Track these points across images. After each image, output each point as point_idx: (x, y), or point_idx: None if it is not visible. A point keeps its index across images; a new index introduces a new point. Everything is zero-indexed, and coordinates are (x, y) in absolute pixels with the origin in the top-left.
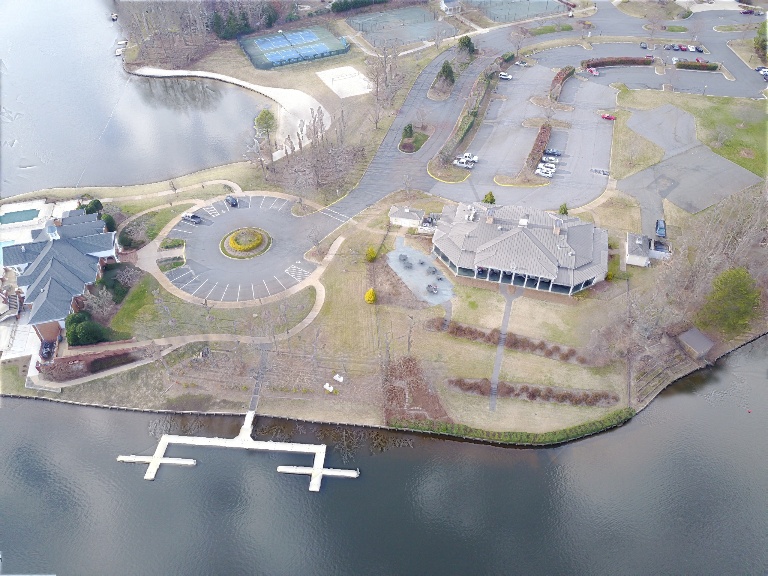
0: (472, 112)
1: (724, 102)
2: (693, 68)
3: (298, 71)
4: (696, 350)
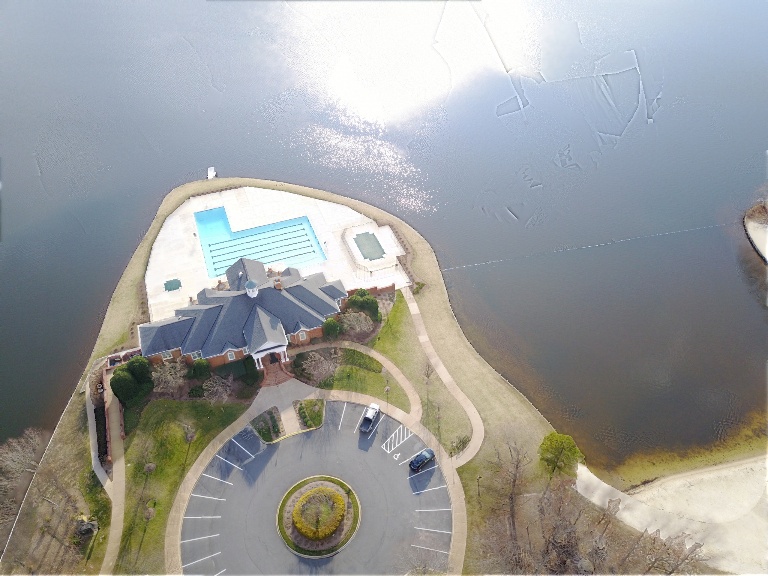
0: None
1: None
2: None
3: None
4: None
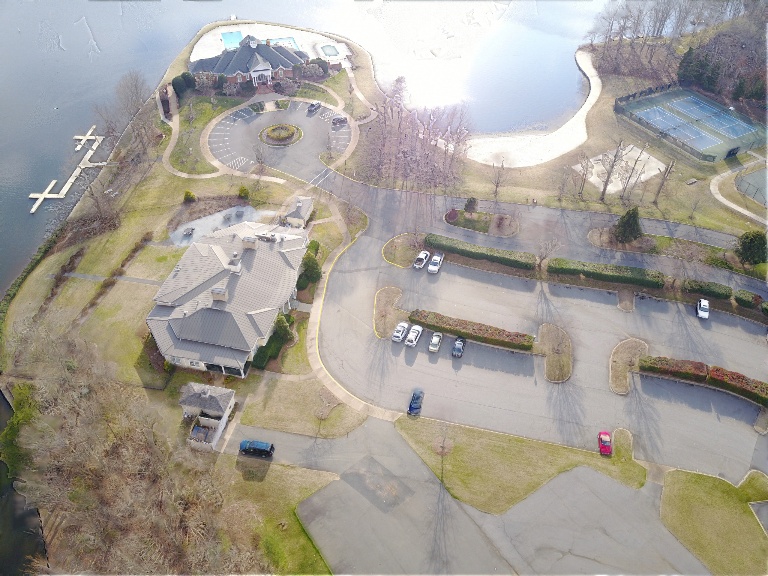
0: (549, 263)
1: None
2: None
3: (629, 133)
4: None
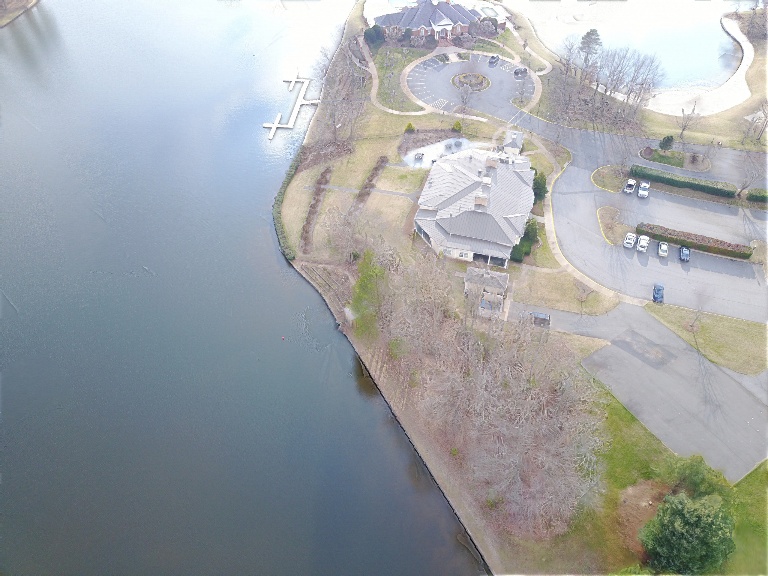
0: (749, 192)
1: None
2: None
3: None
4: None
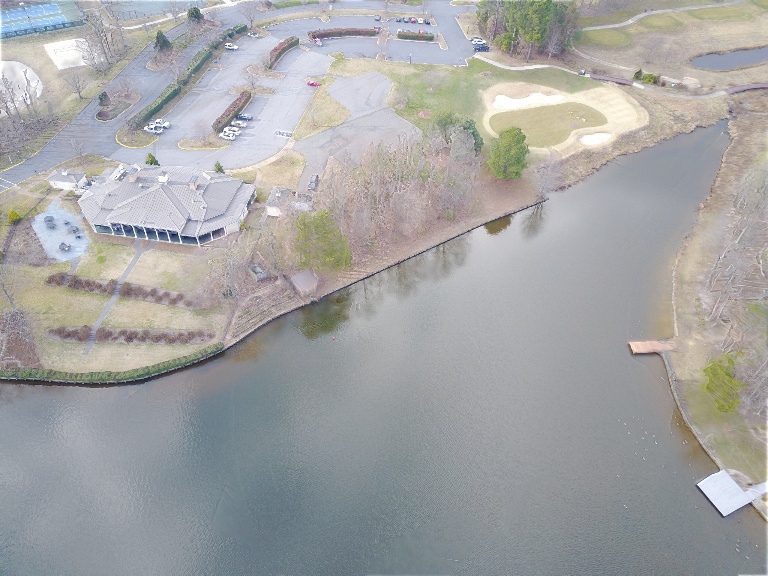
0: (180, 80)
1: (427, 69)
2: (412, 38)
3: (25, 43)
4: (300, 288)
